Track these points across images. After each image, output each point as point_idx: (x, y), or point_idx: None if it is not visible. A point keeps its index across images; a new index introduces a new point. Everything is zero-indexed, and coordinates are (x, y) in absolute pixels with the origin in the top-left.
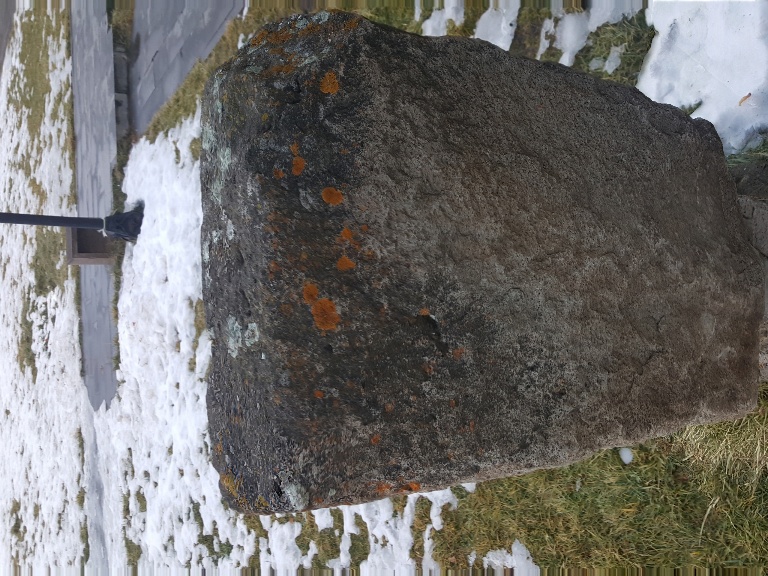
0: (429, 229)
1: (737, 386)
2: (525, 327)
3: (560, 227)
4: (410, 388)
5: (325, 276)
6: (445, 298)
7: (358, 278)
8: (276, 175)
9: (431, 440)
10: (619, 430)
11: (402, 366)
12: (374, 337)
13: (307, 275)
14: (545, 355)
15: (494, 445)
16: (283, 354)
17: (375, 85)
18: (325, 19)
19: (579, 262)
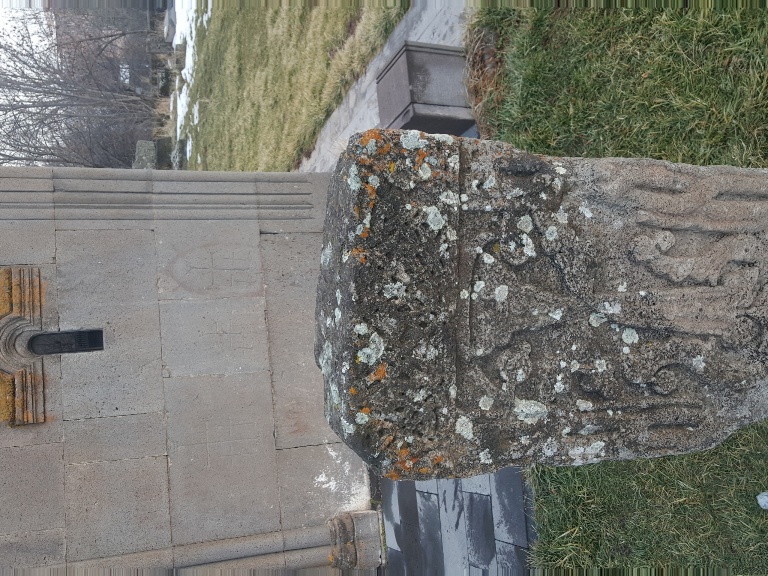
0: None
1: None
2: None
3: None
4: None
5: None
6: None
7: None
8: None
9: None
10: None
11: None
12: None
13: None
14: None
15: None
16: None
17: None
18: None
19: None
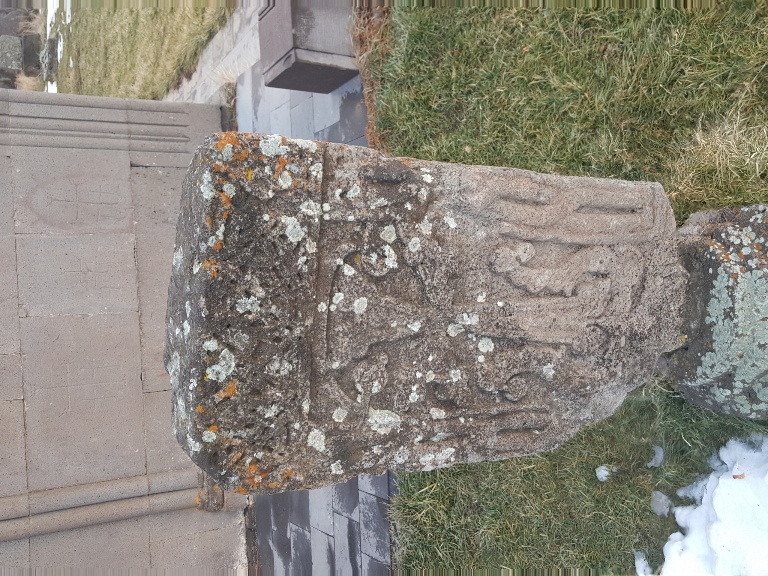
0: None
1: None
2: None
3: None
4: None
5: None
6: None
7: None
8: None
9: None
10: None
11: None
12: None
13: None
14: None
15: None
16: None
17: None
18: None
19: None
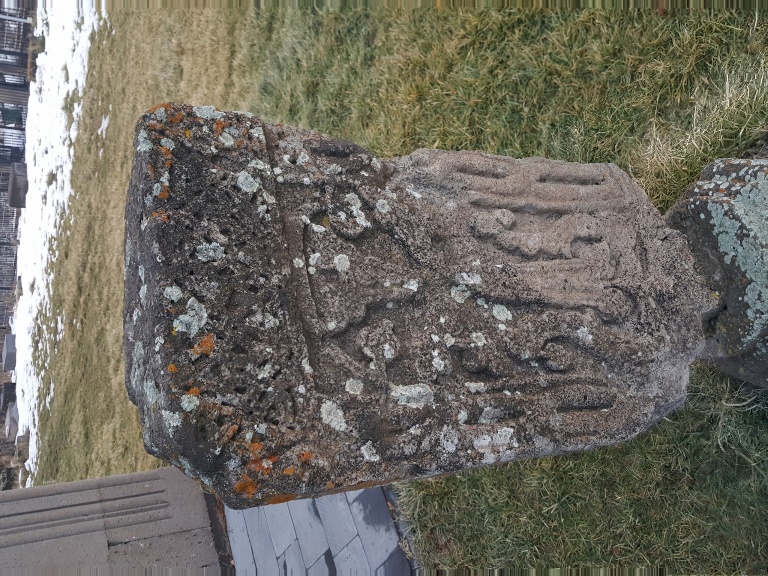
0: None
1: None
2: None
3: None
4: None
5: None
6: None
7: None
8: None
9: None
10: None
11: None
12: None
13: None
14: None
15: None
16: None
17: None
18: None
19: None
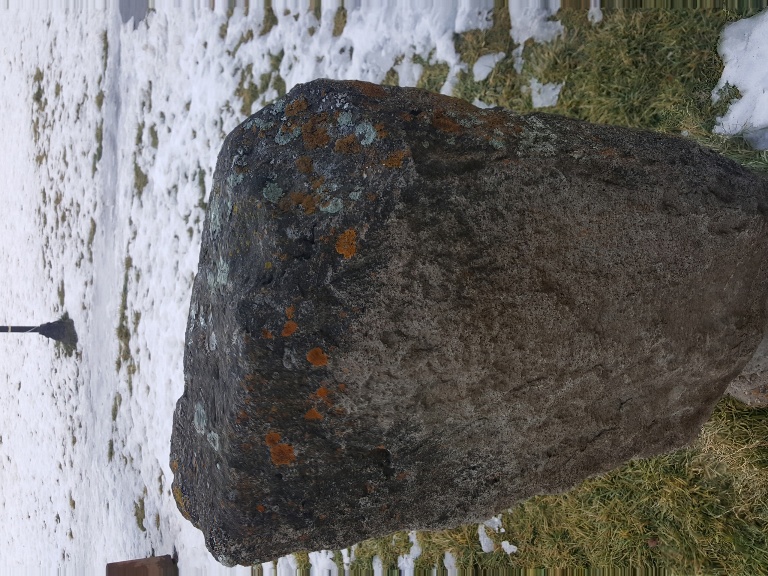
0: (408, 386)
1: (679, 435)
2: (478, 443)
3: (552, 357)
4: (347, 502)
5: (290, 425)
6: (404, 438)
7: (322, 428)
8: (263, 335)
9: (355, 531)
10: (541, 491)
11: (345, 488)
12: (324, 469)
13: (272, 426)
14: (490, 459)
15: (415, 520)
16: (234, 480)
17: (397, 247)
18: (368, 141)
19: (558, 385)
